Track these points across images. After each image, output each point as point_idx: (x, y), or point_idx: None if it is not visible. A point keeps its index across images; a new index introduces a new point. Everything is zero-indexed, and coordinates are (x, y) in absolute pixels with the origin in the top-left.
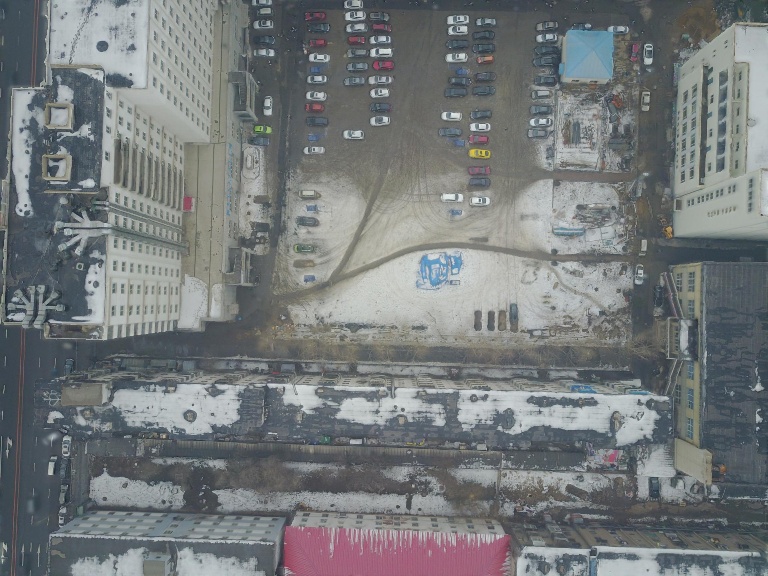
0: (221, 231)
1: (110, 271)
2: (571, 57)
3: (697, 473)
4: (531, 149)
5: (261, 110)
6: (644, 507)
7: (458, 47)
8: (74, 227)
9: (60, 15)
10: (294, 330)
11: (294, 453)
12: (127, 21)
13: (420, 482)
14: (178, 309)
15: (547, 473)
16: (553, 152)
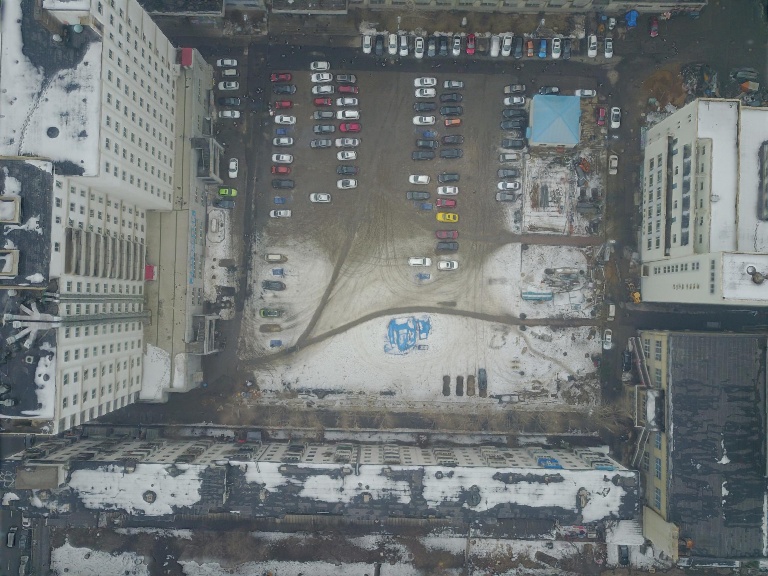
0: (184, 300)
1: (61, 363)
2: (538, 122)
3: (664, 546)
4: (499, 212)
5: (226, 172)
6: (613, 574)
7: (425, 110)
8: (23, 320)
9: (9, 100)
10: (260, 396)
11: (260, 523)
12: (78, 107)
13: (388, 550)
14: (140, 380)
15: (516, 540)
16: (521, 216)
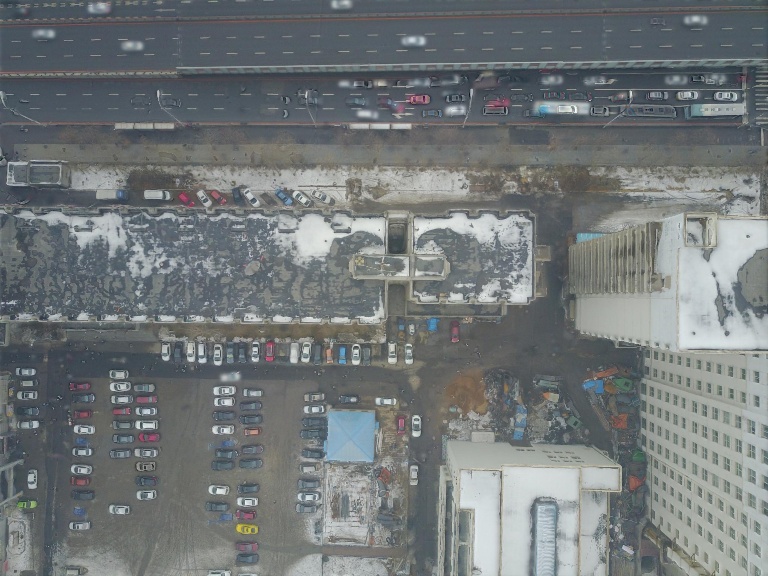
0: None
1: None
2: (331, 441)
3: None
4: (300, 523)
5: (26, 483)
6: None
7: (224, 419)
8: None
9: None
10: None
11: None
12: None
13: None
14: None
15: None
16: (321, 527)
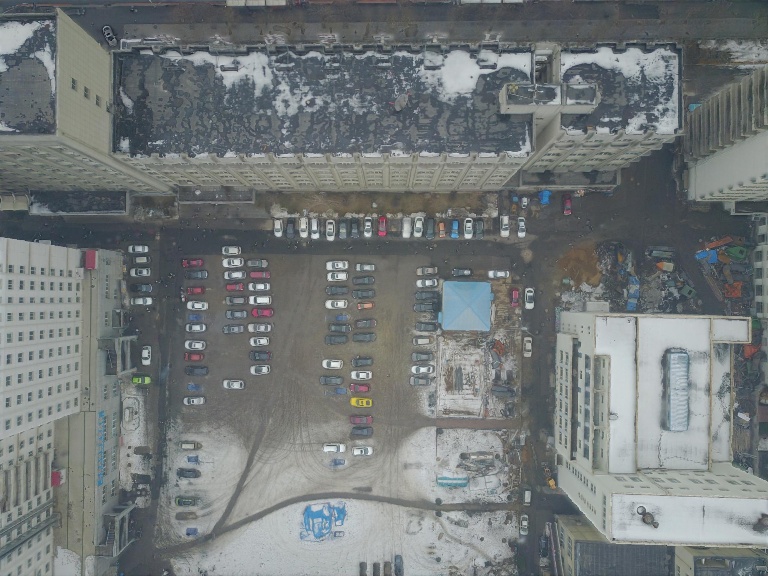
0: (93, 502)
1: None
2: (448, 310)
3: None
4: (414, 396)
5: (140, 360)
6: None
7: (337, 293)
8: None
9: None
10: None
11: None
12: None
13: None
14: None
15: None
16: (435, 399)
